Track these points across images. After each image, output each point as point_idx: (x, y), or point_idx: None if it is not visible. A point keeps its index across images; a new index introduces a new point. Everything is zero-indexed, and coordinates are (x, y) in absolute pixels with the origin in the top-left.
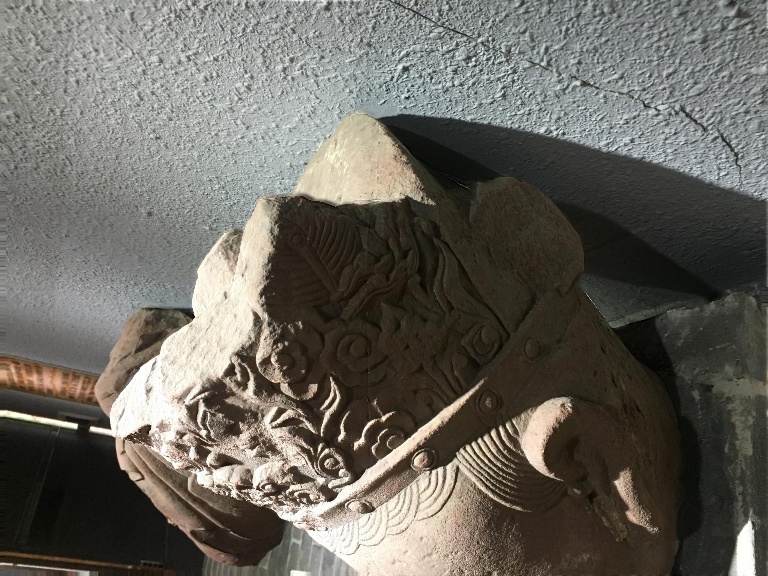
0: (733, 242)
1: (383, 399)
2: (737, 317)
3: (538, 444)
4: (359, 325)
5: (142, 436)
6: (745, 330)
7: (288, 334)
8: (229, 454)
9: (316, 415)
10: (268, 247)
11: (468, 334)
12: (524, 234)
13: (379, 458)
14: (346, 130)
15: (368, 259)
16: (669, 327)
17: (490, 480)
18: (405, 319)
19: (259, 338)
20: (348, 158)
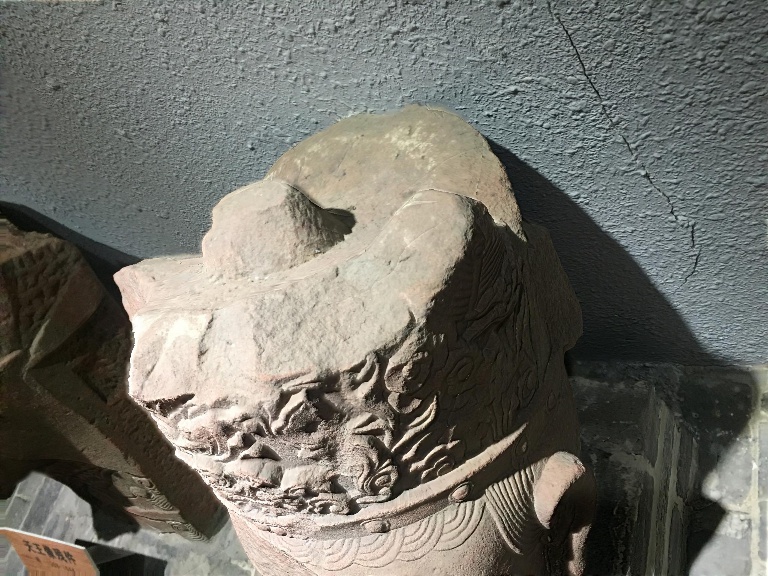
0: (622, 330)
1: (459, 427)
2: (644, 402)
3: (555, 495)
4: (476, 350)
5: (171, 403)
6: (648, 414)
7: (429, 344)
8: (274, 447)
9: (399, 430)
10: (459, 250)
11: (523, 376)
12: (553, 288)
13: (422, 482)
14: (433, 124)
15: (504, 286)
16: (575, 391)
17: (508, 521)
18: (503, 352)
19: (404, 341)
20: (438, 156)
